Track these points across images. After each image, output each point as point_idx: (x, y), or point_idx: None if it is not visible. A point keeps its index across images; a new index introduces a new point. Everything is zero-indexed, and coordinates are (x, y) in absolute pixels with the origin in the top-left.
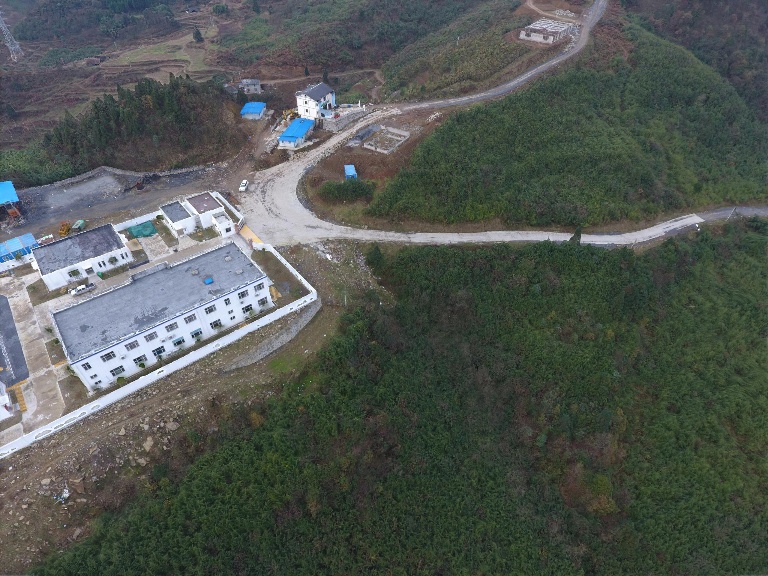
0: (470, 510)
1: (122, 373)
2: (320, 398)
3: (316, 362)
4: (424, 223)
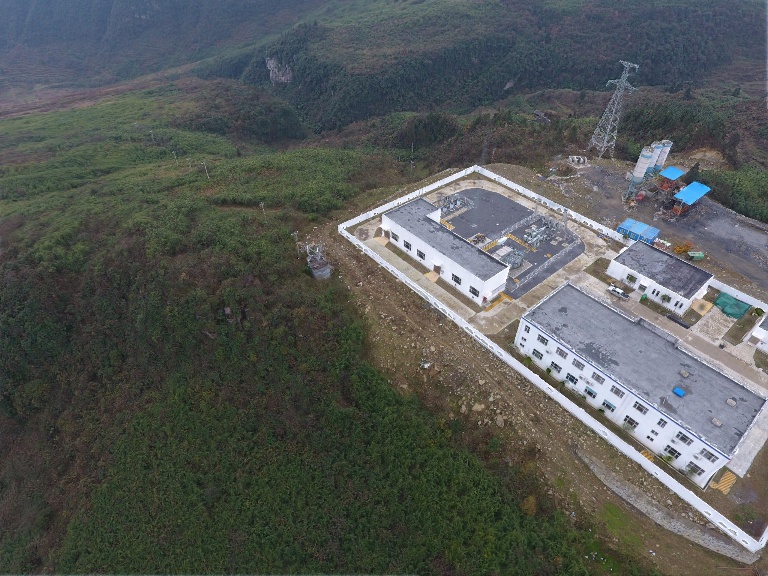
0: None
1: (538, 359)
2: None
3: (639, 571)
4: None
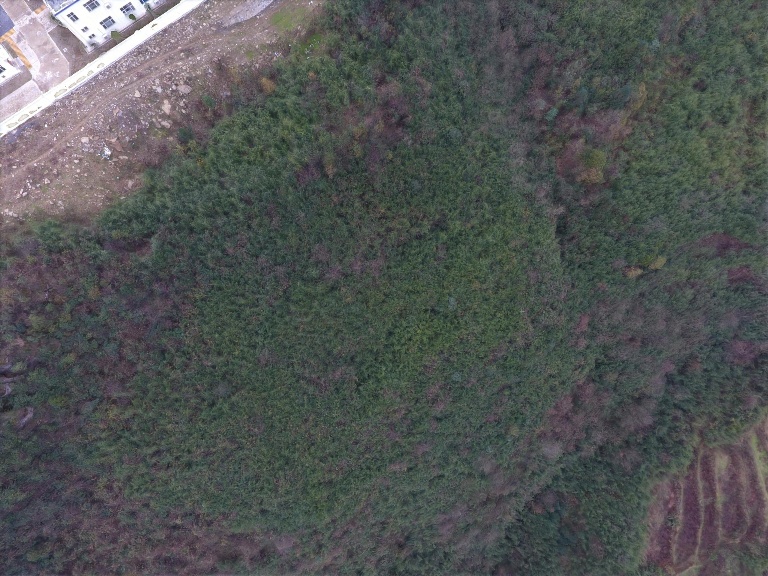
0: (470, 177)
1: (113, 25)
2: (330, 63)
3: (323, 18)
4: None
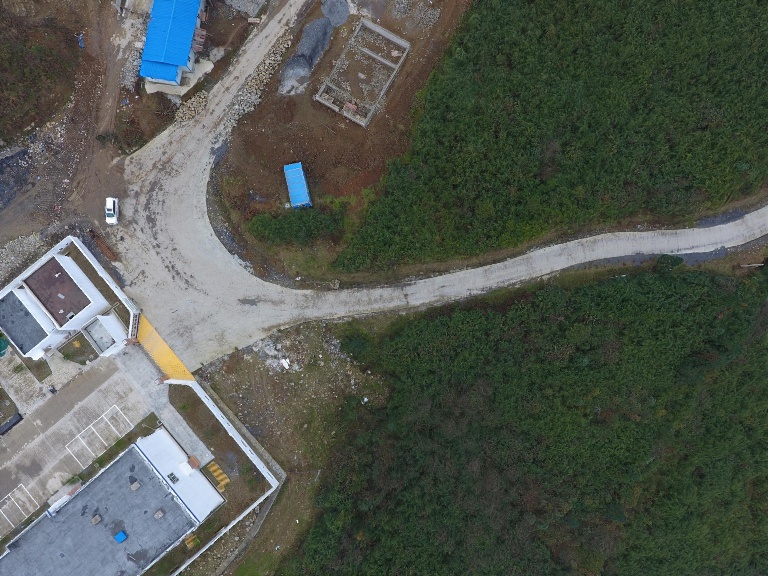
0: None
1: None
2: None
3: (292, 569)
4: (430, 263)
